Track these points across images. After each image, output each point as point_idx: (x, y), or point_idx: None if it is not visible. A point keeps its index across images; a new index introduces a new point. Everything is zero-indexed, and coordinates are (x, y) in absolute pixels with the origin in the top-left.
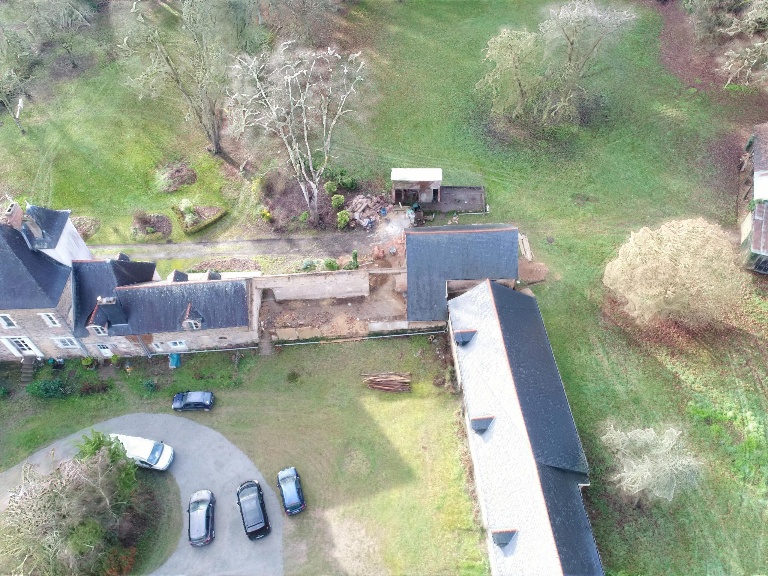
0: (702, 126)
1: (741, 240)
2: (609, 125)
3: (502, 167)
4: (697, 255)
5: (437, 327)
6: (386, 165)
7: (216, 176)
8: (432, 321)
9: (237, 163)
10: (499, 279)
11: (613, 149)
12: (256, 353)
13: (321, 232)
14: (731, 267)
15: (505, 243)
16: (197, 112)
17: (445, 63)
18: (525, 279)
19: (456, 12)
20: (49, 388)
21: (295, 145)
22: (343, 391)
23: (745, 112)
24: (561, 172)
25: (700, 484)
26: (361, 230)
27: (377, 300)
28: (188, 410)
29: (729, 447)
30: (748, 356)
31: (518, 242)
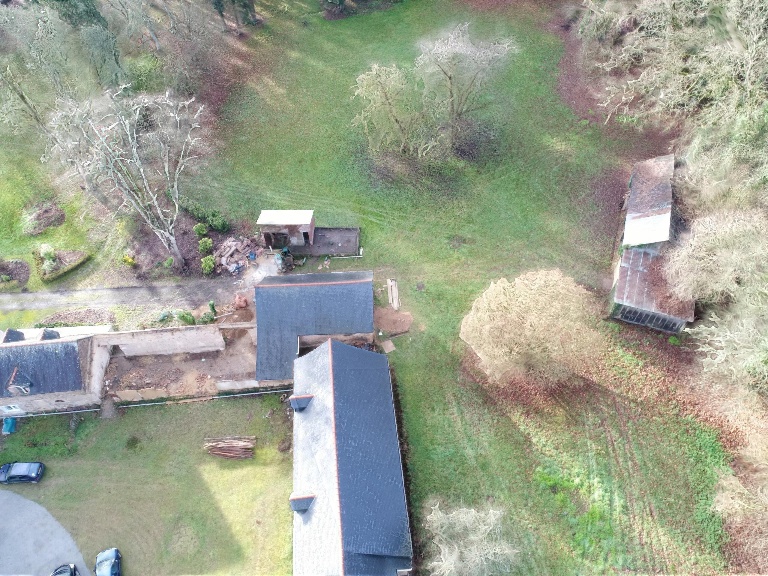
0: (589, 161)
1: (612, 286)
2: (496, 160)
3: (382, 206)
4: (544, 313)
5: (291, 385)
6: (264, 204)
7: (86, 217)
8: (283, 379)
9: (110, 202)
10: (354, 334)
11: (497, 186)
12: (97, 416)
13: (185, 279)
14: (577, 326)
15: (359, 296)
16: (63, 150)
17: (341, 92)
18: (388, 330)
19: (359, 37)
20: None
21: (127, 197)
22: (183, 458)
23: (634, 146)
24: (441, 211)
25: (537, 561)
26: (227, 276)
27: (233, 355)
28: (14, 483)
29: (571, 518)
30: (604, 415)
31: (387, 289)
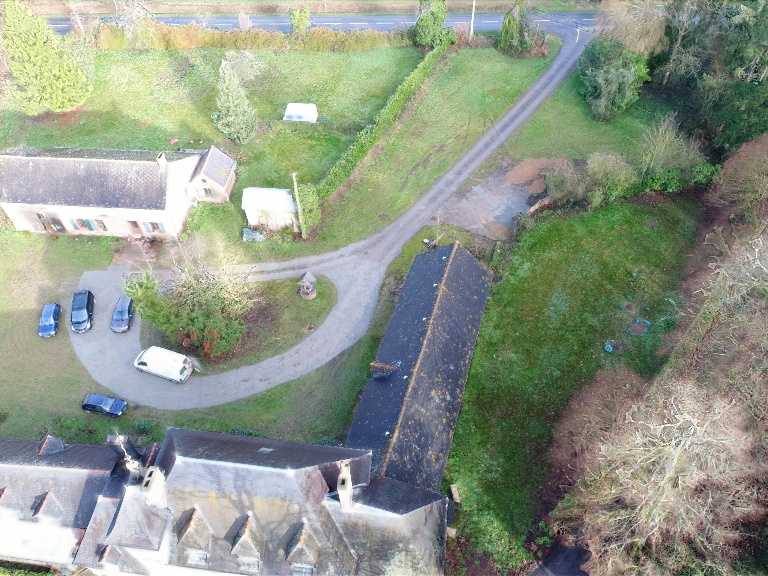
0: None
1: None
2: None
3: None
4: None
5: None
6: None
7: None
8: None
9: None
10: None
11: None
12: None
13: None
14: None
15: None
16: None
17: None
18: None
19: None
20: (241, 433)
21: None
22: None
23: None
24: None
25: None
26: None
27: None
28: None
29: None
30: None
31: None
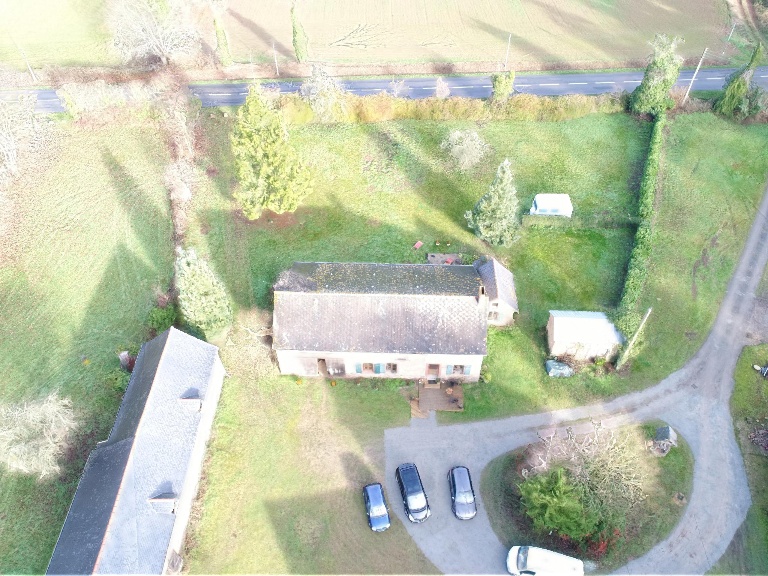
0: None
1: None
2: None
3: None
4: None
5: None
6: None
7: None
8: None
9: None
10: None
11: None
12: None
13: None
14: None
15: None
16: None
17: None
18: None
19: None
20: None
21: None
22: None
23: None
24: None
25: None
26: None
27: None
28: None
29: None
30: None
31: None
